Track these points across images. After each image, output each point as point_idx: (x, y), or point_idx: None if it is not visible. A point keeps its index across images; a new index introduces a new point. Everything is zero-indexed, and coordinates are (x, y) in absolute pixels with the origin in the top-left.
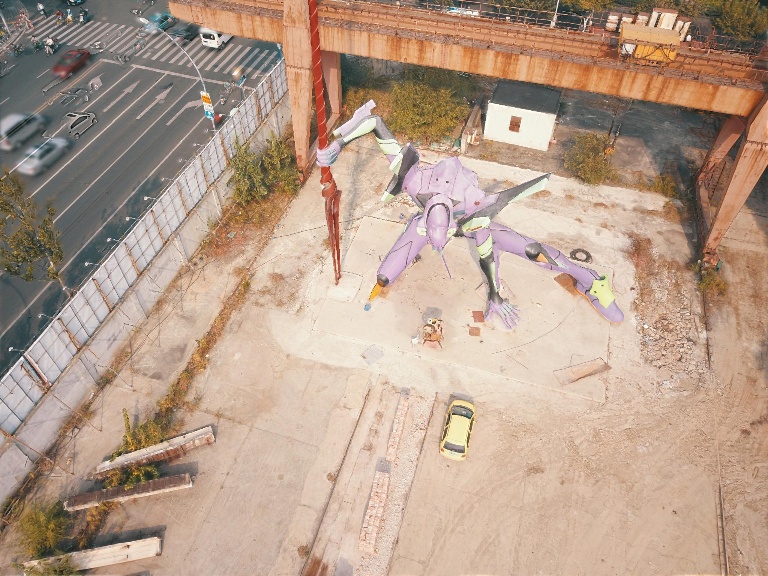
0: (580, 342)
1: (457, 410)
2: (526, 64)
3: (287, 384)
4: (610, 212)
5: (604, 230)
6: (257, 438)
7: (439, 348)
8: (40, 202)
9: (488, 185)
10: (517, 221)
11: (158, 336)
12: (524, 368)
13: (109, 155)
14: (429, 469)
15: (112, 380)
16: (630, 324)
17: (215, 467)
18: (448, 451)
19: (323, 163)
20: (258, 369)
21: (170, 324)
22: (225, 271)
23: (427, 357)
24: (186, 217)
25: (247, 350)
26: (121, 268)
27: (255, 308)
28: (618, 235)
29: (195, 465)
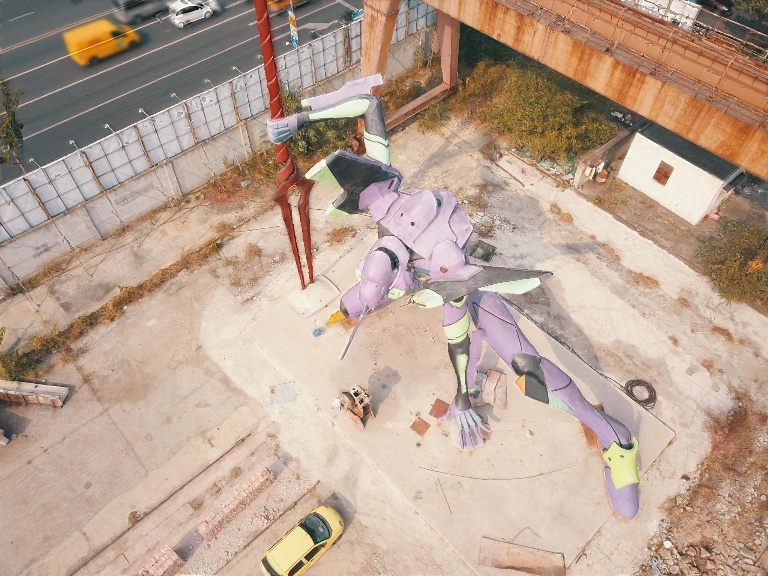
0: (550, 515)
1: (314, 521)
2: (654, 92)
3: (174, 380)
4: (731, 349)
5: (703, 371)
6: (100, 426)
7: (361, 426)
8: (104, 81)
9: (579, 240)
10: (584, 304)
11: (99, 264)
12: (447, 510)
13: (196, 54)
14: (239, 575)
15: (28, 290)
16: (645, 528)
17: (41, 436)
18: (265, 569)
19: (271, 137)
20: (160, 347)
21: (118, 256)
22: (210, 221)
23: (341, 429)
24: (192, 146)
25: (166, 320)
26: (74, 177)
27: (208, 276)
28: (720, 388)
29: (26, 423)
